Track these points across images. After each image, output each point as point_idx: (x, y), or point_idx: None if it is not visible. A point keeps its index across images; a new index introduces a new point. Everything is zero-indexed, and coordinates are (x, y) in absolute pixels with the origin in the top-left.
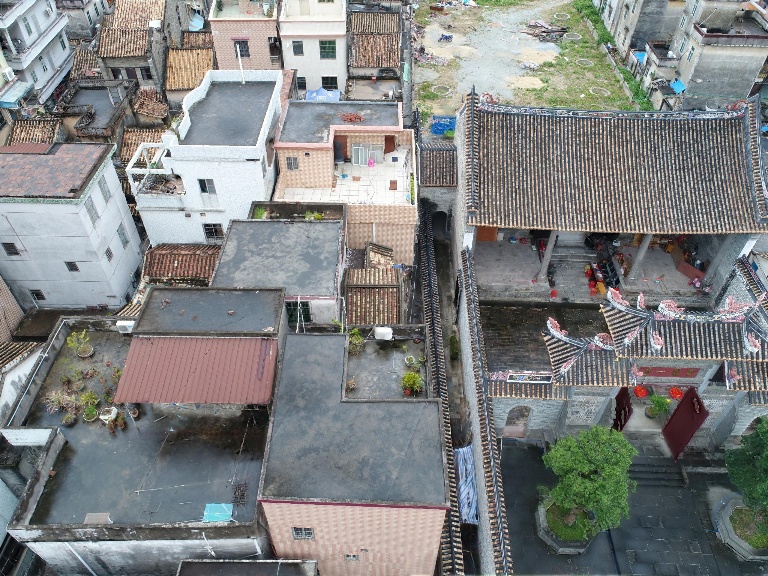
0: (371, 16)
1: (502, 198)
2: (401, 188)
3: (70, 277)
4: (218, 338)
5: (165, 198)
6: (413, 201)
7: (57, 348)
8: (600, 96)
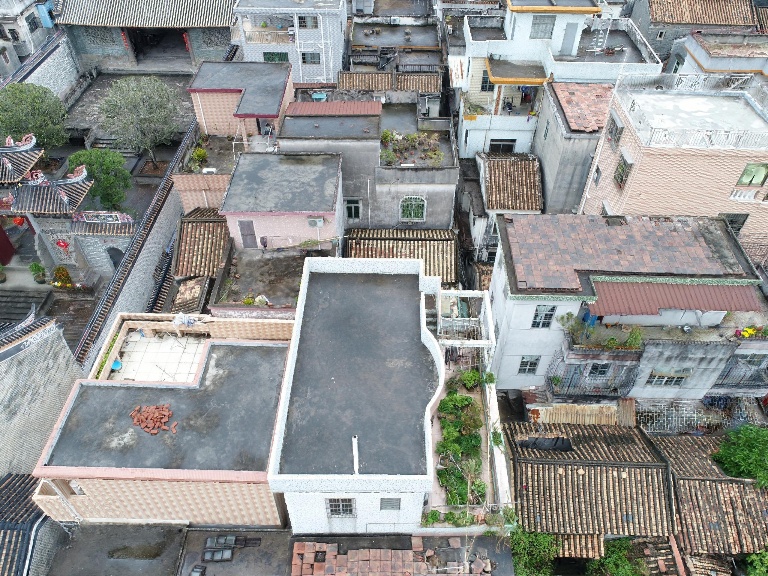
0: None
1: None
2: None
3: None
4: None
5: None
6: None
7: None
8: None
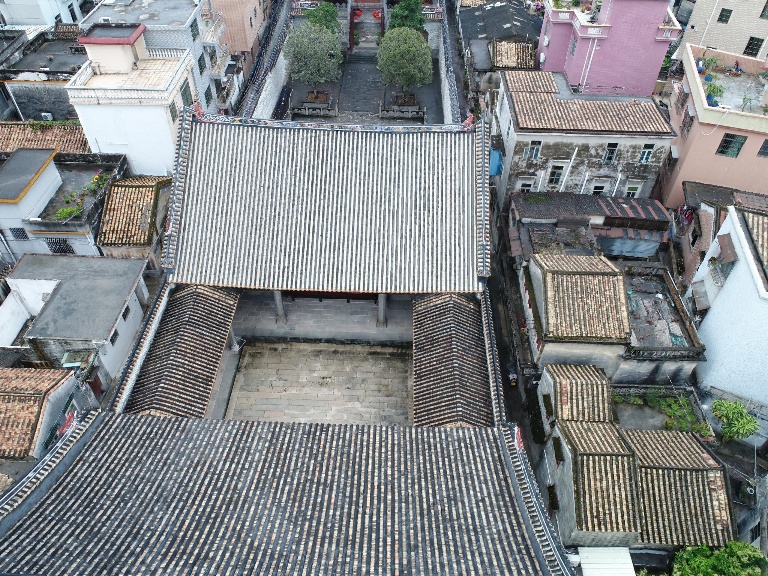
0: None
1: None
2: None
3: None
4: None
5: None
6: None
7: None
8: None
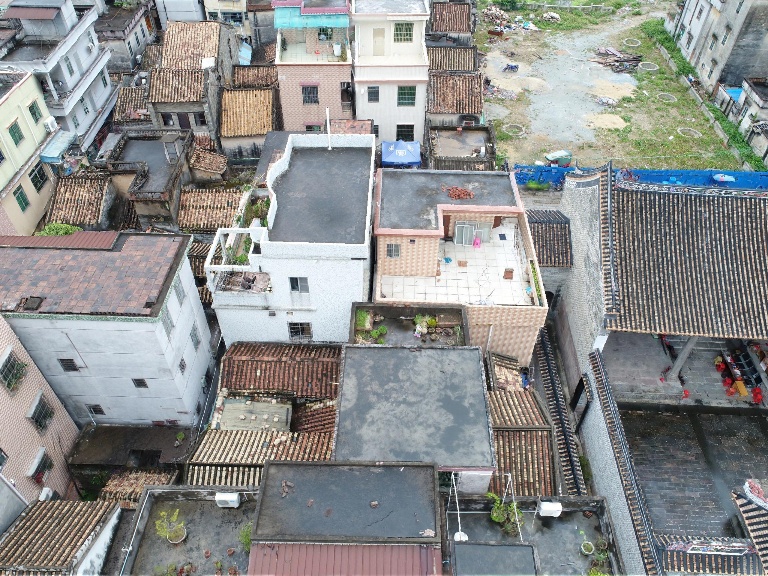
0: (443, 51)
1: (645, 296)
2: (517, 277)
3: (136, 393)
4: (362, 545)
5: (247, 296)
6: (540, 300)
7: (141, 530)
8: (691, 138)
